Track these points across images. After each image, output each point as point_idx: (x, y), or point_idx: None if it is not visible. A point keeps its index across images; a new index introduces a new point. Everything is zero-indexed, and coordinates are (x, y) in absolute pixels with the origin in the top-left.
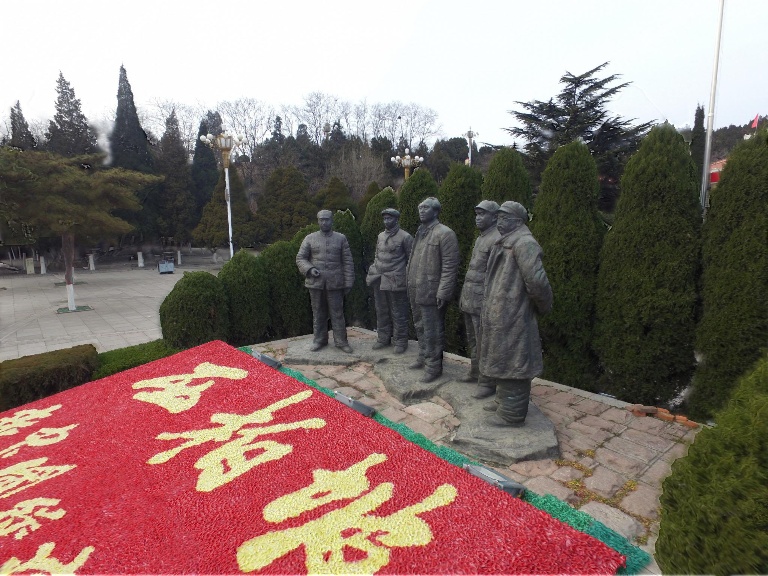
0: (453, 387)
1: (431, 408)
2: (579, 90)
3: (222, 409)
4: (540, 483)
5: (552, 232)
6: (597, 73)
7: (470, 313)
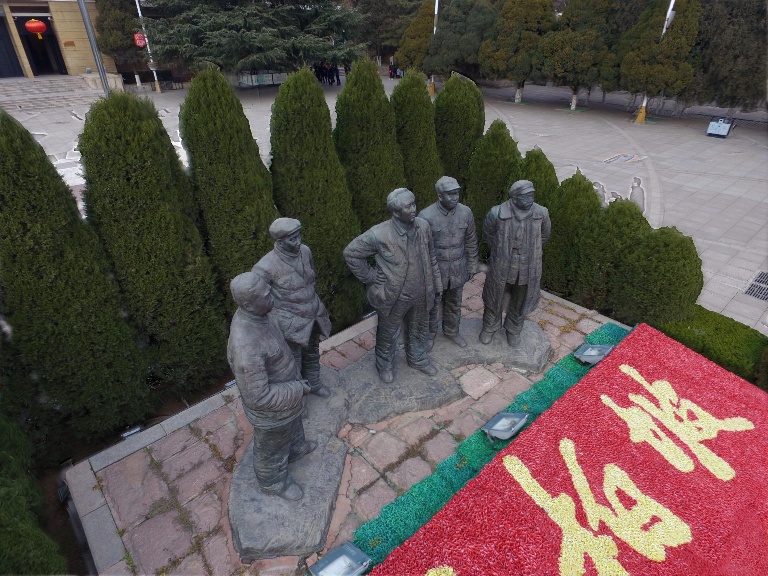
0: (442, 356)
1: (478, 377)
2: None
3: (551, 572)
4: (571, 340)
5: (329, 179)
6: None
7: None
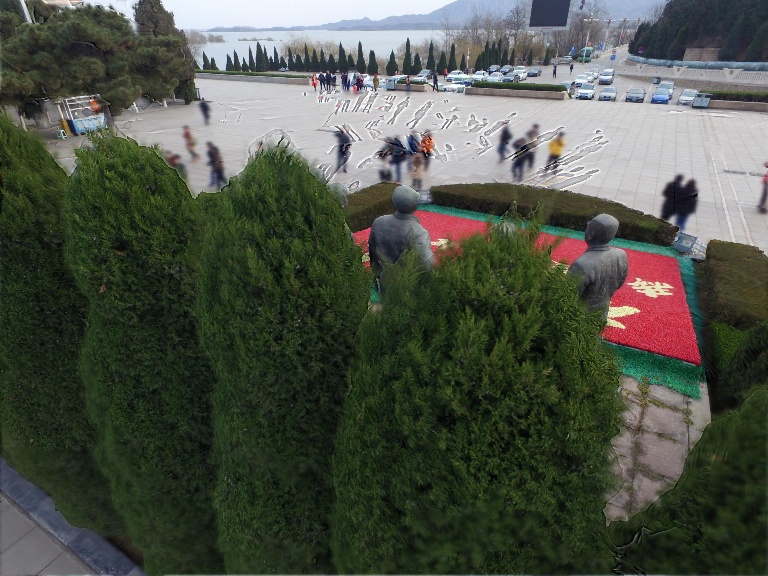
0: None
1: None
2: None
3: None
4: None
5: None
6: None
7: None
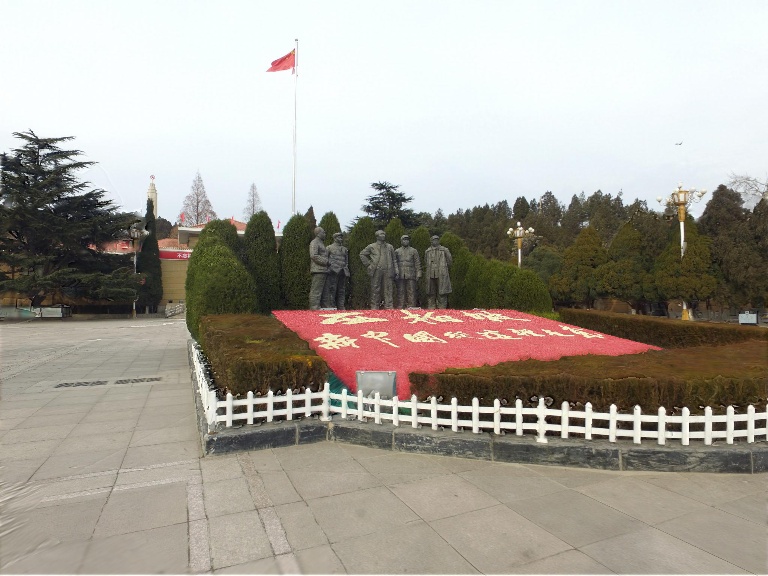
0: None
1: None
2: (42, 152)
3: None
4: None
5: None
6: (61, 143)
7: (411, 279)
